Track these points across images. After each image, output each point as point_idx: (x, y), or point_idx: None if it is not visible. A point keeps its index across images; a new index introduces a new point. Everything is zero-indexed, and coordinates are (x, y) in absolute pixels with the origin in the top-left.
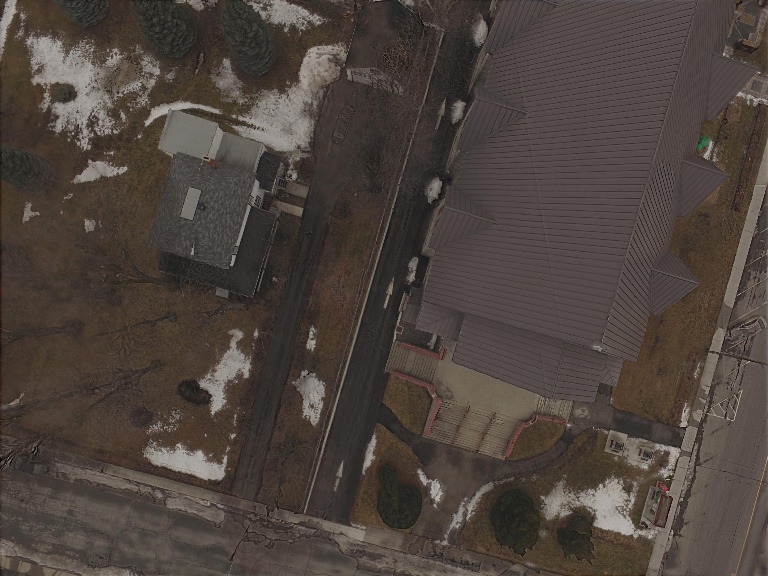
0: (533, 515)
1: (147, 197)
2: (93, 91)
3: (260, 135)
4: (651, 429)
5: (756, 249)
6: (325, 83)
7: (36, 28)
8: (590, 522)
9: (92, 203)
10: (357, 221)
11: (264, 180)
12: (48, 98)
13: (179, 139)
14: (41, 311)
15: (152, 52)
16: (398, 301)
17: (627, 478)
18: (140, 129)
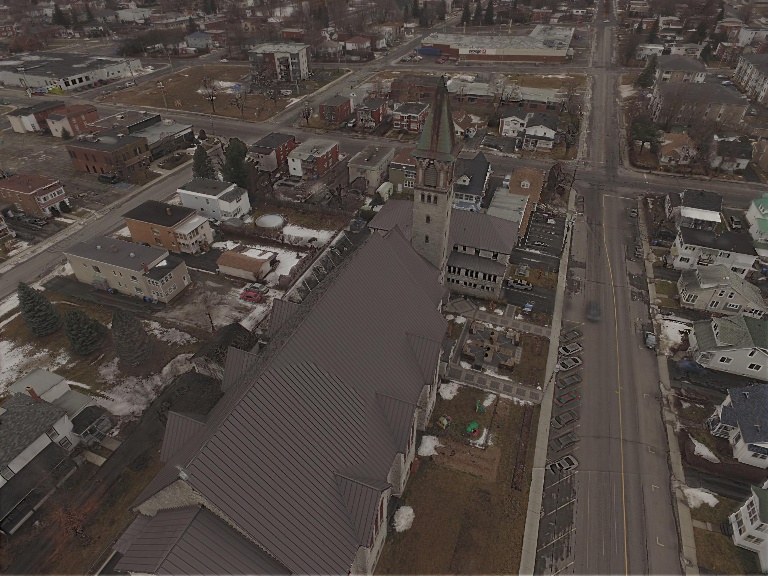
0: None
1: None
2: (10, 371)
3: (108, 403)
4: None
5: (546, 532)
6: (178, 374)
7: (5, 336)
8: None
9: None
10: (148, 474)
11: (79, 424)
12: None
13: None
14: None
15: (70, 352)
16: None
17: None
18: None
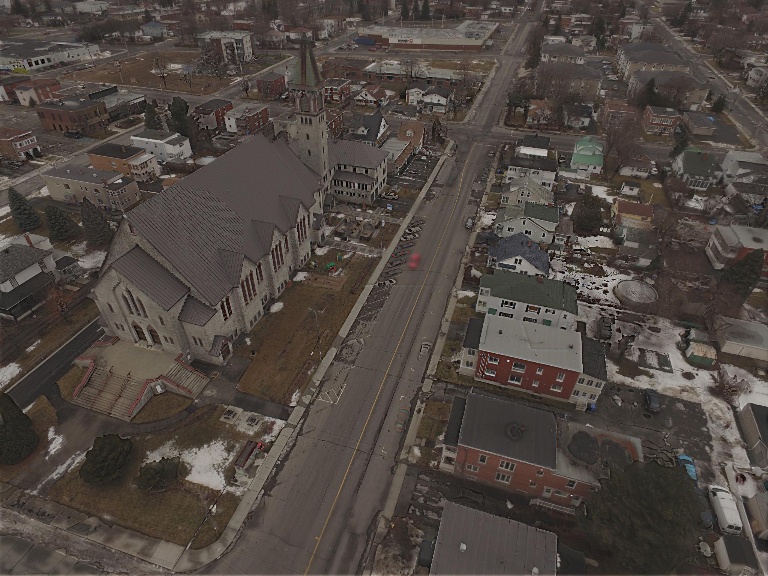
0: (117, 434)
1: None
2: None
3: (80, 263)
4: (264, 406)
5: (365, 311)
6: None
7: None
8: (177, 464)
9: None
10: None
11: (60, 265)
12: None
13: None
14: None
15: (49, 239)
16: None
17: (232, 441)
18: None
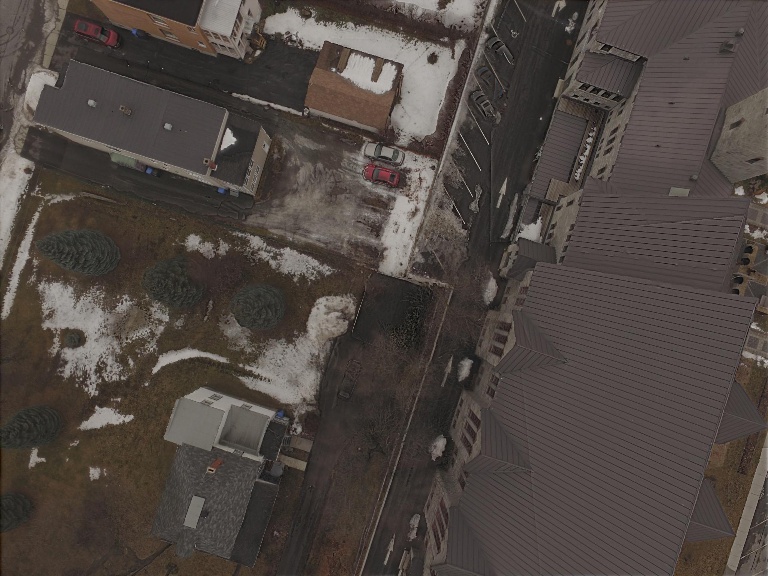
0: None
1: (152, 448)
2: (102, 337)
3: (266, 387)
4: None
5: (762, 512)
6: (332, 336)
7: (48, 274)
8: None
9: (98, 451)
10: (360, 475)
11: (268, 452)
12: (58, 343)
13: (185, 429)
14: (44, 558)
15: None
16: (398, 558)
17: None
18: (147, 376)
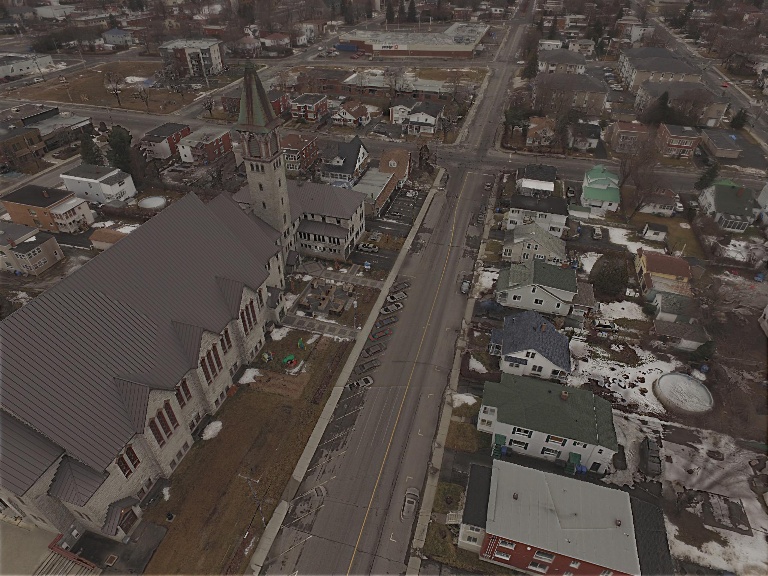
0: None
1: None
2: None
3: None
4: None
5: (331, 432)
6: None
7: None
8: None
9: None
10: None
11: None
12: None
13: None
14: None
15: None
16: None
17: None
18: None
